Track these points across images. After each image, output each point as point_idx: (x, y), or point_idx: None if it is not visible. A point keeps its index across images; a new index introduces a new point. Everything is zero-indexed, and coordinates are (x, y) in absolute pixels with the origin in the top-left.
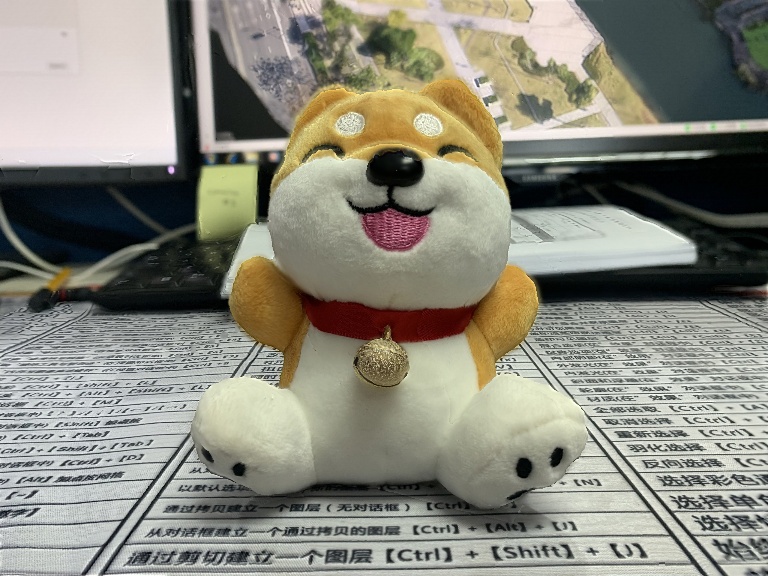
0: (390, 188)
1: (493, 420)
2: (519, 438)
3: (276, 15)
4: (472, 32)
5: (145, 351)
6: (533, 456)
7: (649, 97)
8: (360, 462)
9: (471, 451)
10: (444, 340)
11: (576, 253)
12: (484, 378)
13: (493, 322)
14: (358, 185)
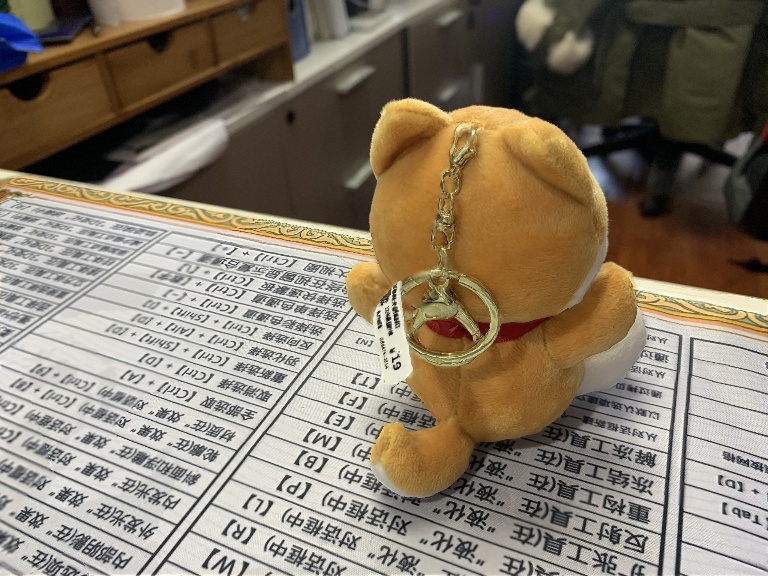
0: None
1: None
2: None
3: None
4: None
5: None
6: None
7: None
8: None
9: None
10: None
11: None
12: None
13: None
14: None
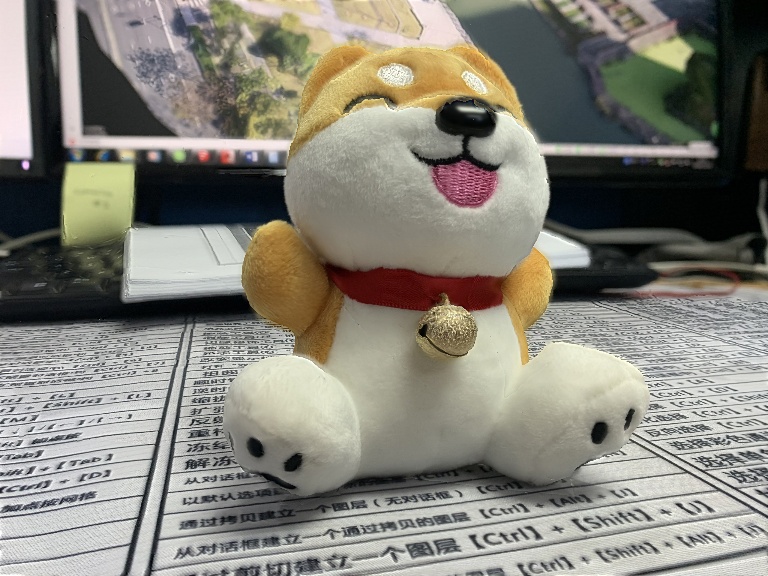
0: (465, 138)
1: (565, 386)
2: (596, 402)
3: (157, 3)
4: (365, 43)
5: (38, 363)
6: (612, 419)
7: (525, 119)
8: (412, 447)
9: (543, 421)
10: (492, 310)
11: None
12: (524, 350)
13: (521, 295)
14: (427, 134)
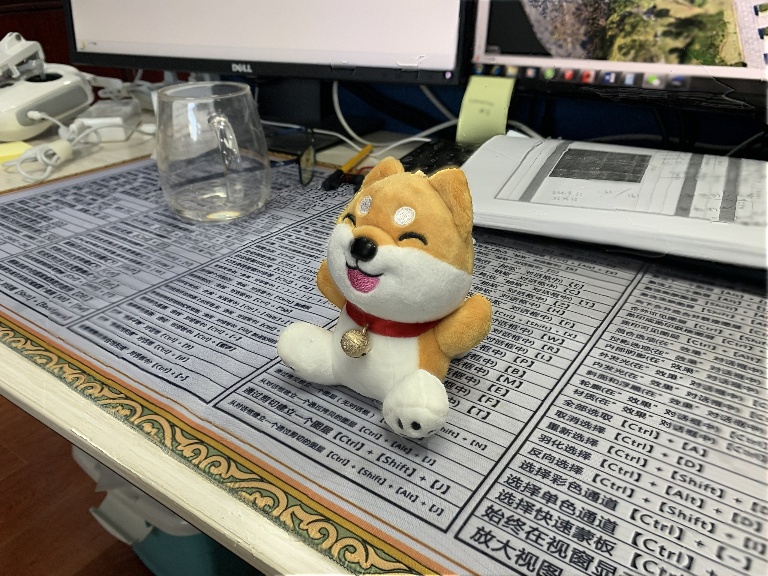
0: (357, 260)
1: (395, 394)
2: (399, 409)
3: None
4: None
5: None
6: (401, 421)
7: None
8: (352, 385)
9: None
10: (400, 339)
11: (737, 244)
12: (424, 366)
13: (445, 334)
14: (347, 251)
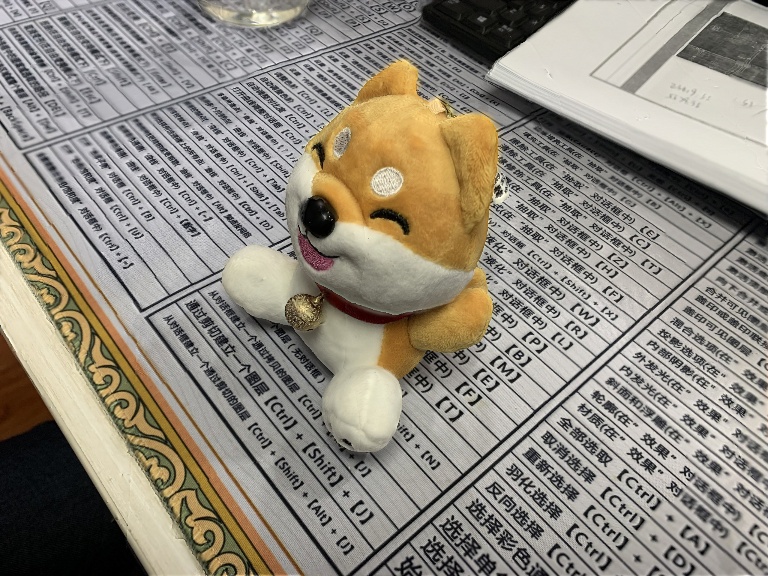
0: (307, 229)
1: (334, 394)
2: (333, 416)
3: None
4: None
5: None
6: None
7: None
8: None
9: None
10: (361, 322)
11: None
12: (385, 359)
13: (420, 330)
14: (300, 208)
